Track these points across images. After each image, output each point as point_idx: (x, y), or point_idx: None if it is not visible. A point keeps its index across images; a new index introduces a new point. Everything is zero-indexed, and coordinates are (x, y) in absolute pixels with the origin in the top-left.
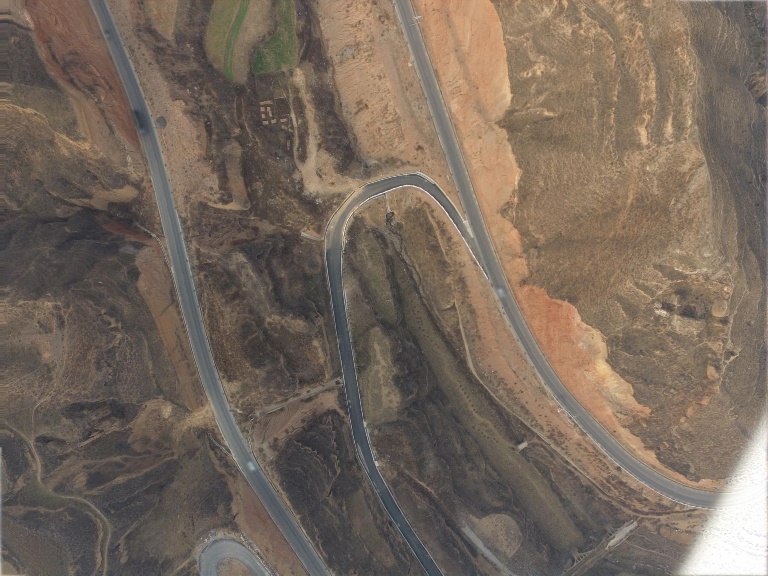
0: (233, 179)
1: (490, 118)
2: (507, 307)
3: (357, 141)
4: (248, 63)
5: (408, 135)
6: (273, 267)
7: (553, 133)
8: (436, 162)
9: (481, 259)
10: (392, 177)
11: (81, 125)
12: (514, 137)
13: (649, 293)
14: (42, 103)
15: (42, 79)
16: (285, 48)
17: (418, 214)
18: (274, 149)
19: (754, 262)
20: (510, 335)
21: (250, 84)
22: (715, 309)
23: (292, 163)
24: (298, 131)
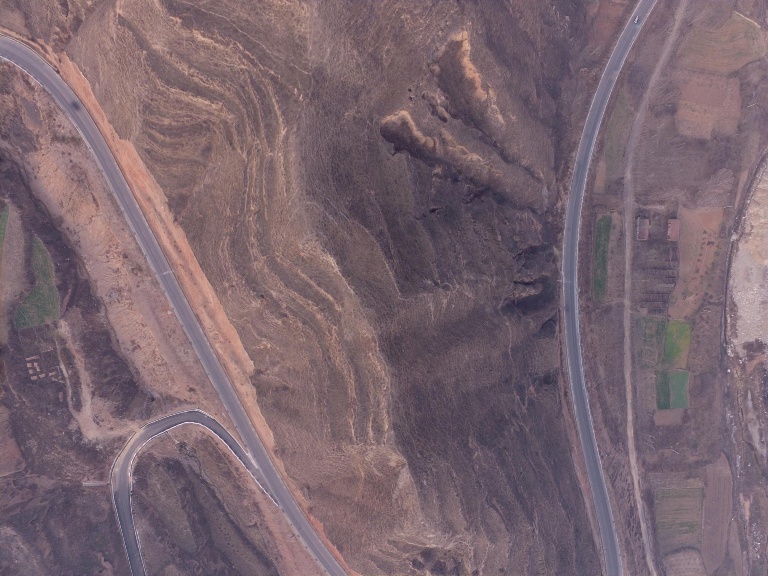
0: None
1: (246, 370)
2: (301, 530)
3: (139, 374)
4: (8, 322)
5: (177, 380)
6: (51, 528)
7: (289, 405)
8: (210, 402)
9: (269, 488)
10: (171, 415)
11: None
12: (261, 400)
13: (395, 557)
14: None
15: None
16: (46, 301)
17: (206, 444)
18: (45, 405)
19: (496, 516)
20: (307, 556)
21: (12, 343)
22: (464, 562)
23: (67, 413)
24: (70, 381)
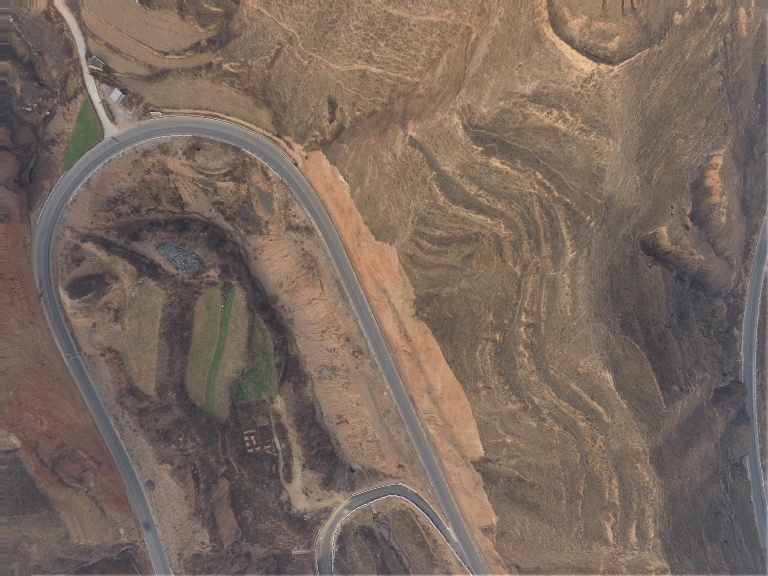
0: (223, 521)
1: (466, 454)
2: None
3: (340, 446)
4: (229, 397)
5: (388, 457)
6: None
7: (526, 497)
8: (417, 478)
9: (466, 560)
10: (376, 488)
11: (74, 534)
12: (489, 487)
13: None
14: (35, 527)
15: (33, 499)
16: (264, 377)
17: (403, 515)
18: (260, 476)
19: None
20: None
21: (233, 417)
22: None
23: (279, 484)
24: (282, 454)
